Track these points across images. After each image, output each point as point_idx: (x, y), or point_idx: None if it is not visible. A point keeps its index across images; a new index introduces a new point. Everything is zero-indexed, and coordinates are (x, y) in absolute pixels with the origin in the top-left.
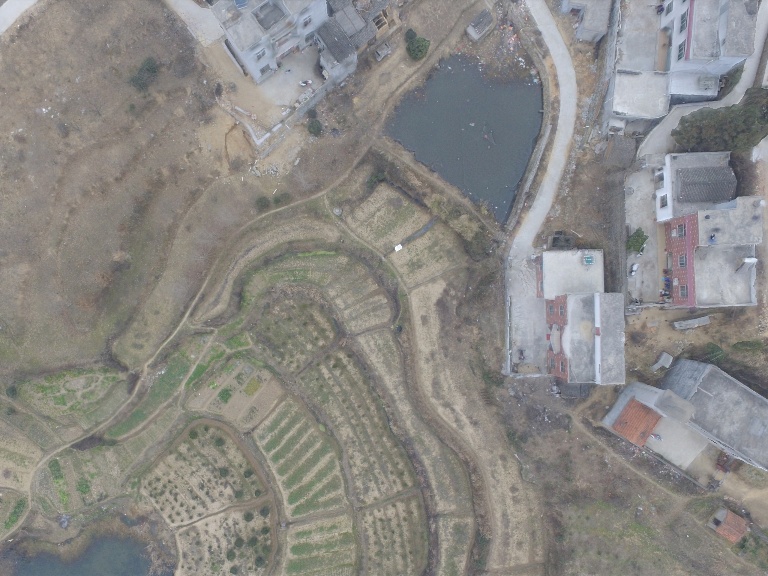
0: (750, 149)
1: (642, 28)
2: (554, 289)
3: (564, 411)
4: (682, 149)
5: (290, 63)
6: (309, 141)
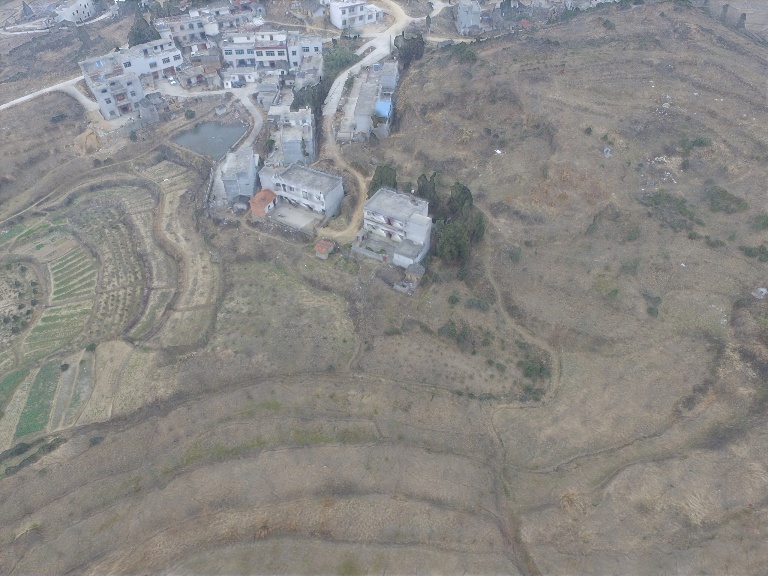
0: None
1: (290, 103)
2: None
3: (236, 219)
4: None
5: (127, 115)
6: (130, 143)
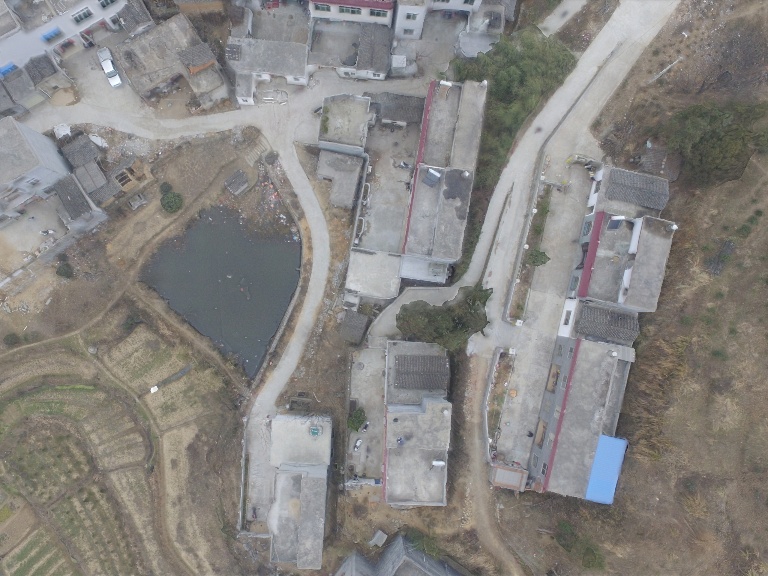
0: (466, 343)
1: (390, 203)
2: (280, 457)
3: (295, 571)
4: (402, 336)
5: (34, 210)
6: (62, 282)
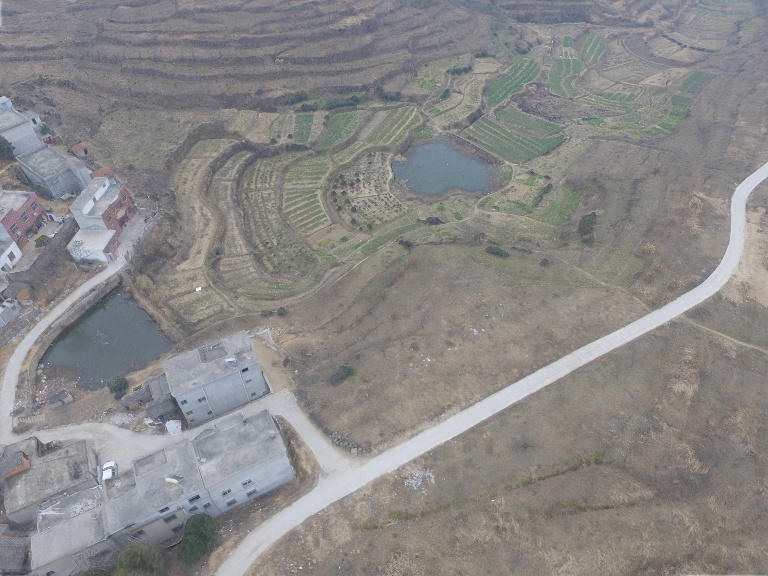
0: None
1: None
2: (108, 234)
3: (137, 199)
4: None
5: None
6: None
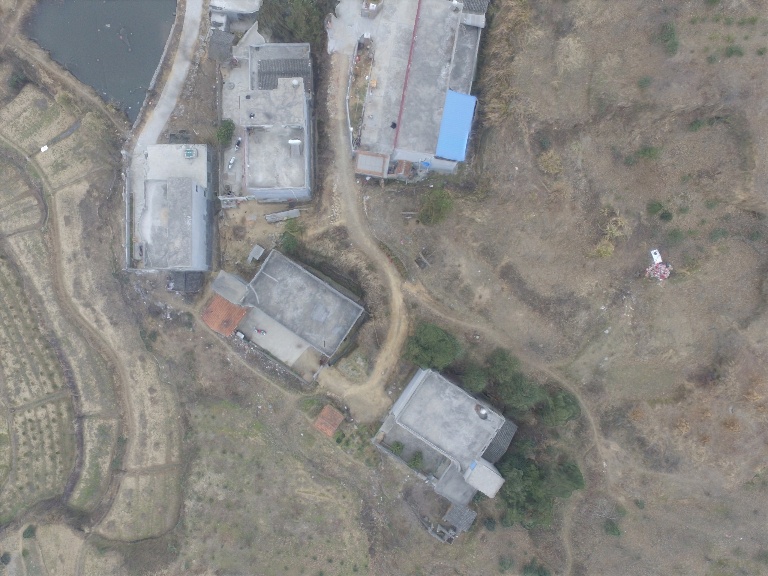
0: (326, 41)
1: None
2: None
3: (186, 309)
4: None
5: None
6: None
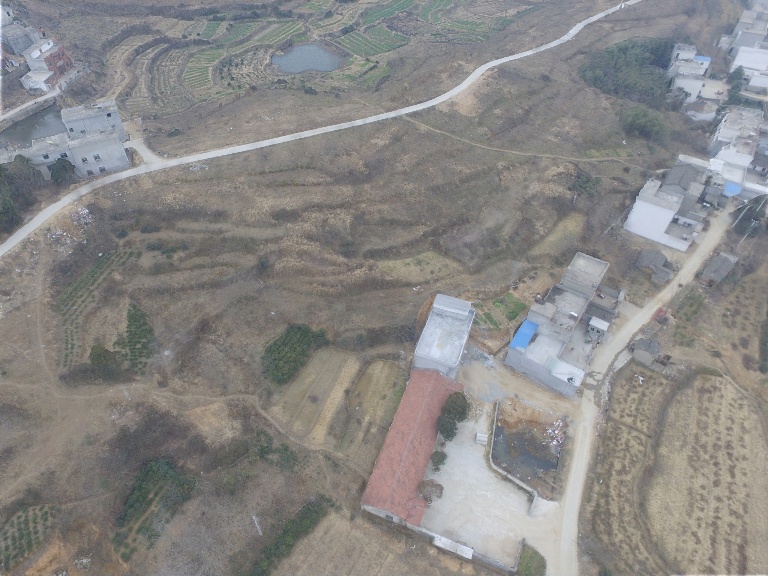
0: None
1: None
2: (49, 73)
3: None
4: None
5: None
6: None
